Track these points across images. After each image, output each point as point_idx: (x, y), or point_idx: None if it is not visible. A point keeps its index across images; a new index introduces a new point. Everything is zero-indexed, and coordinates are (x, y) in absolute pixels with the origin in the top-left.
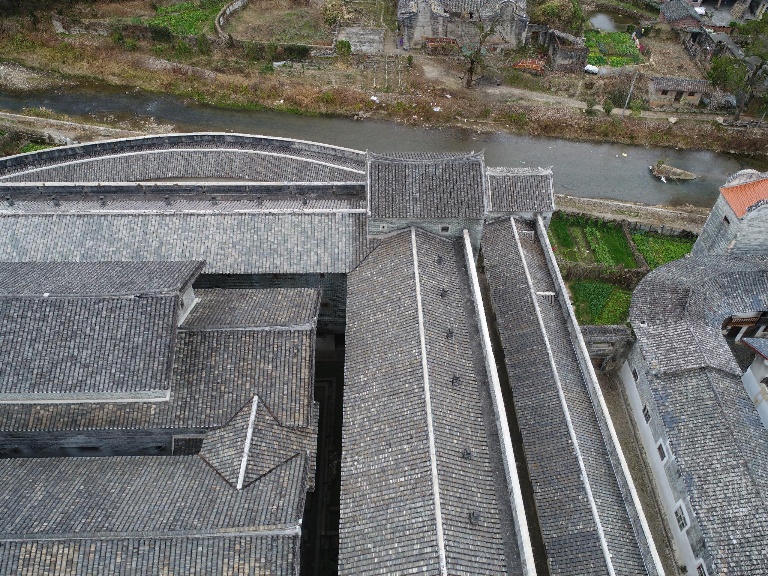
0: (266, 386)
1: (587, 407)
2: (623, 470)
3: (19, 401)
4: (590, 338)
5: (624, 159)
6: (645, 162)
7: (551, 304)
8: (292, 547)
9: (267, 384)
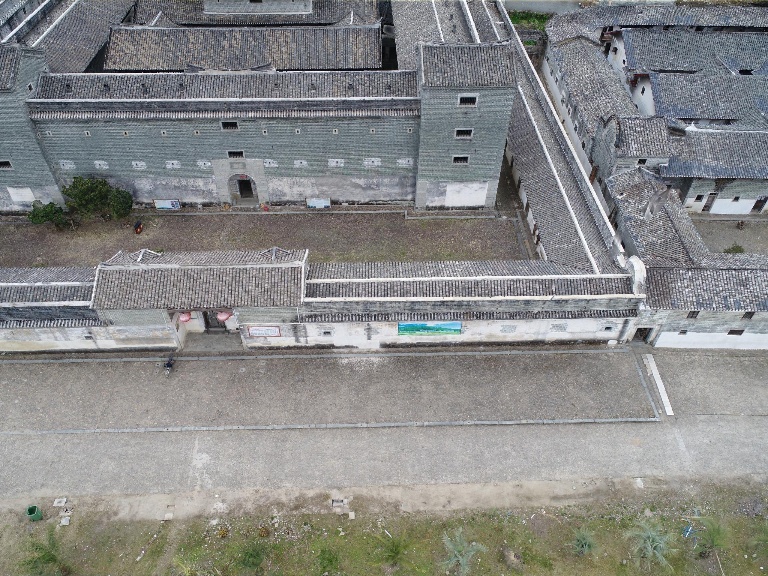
0: (357, 8)
1: (517, 58)
2: (531, 67)
3: (241, 13)
4: (522, 37)
5: (563, 0)
6: (577, 2)
7: (502, 28)
8: (378, 31)
9: (357, 7)
